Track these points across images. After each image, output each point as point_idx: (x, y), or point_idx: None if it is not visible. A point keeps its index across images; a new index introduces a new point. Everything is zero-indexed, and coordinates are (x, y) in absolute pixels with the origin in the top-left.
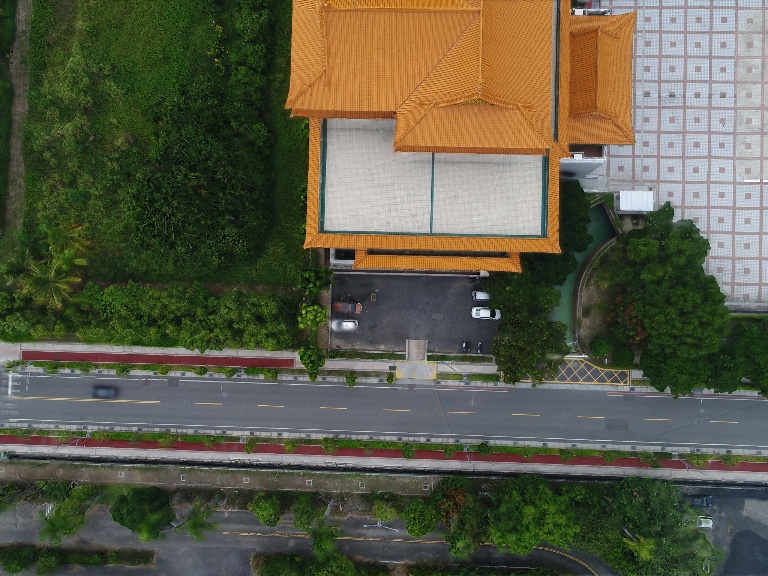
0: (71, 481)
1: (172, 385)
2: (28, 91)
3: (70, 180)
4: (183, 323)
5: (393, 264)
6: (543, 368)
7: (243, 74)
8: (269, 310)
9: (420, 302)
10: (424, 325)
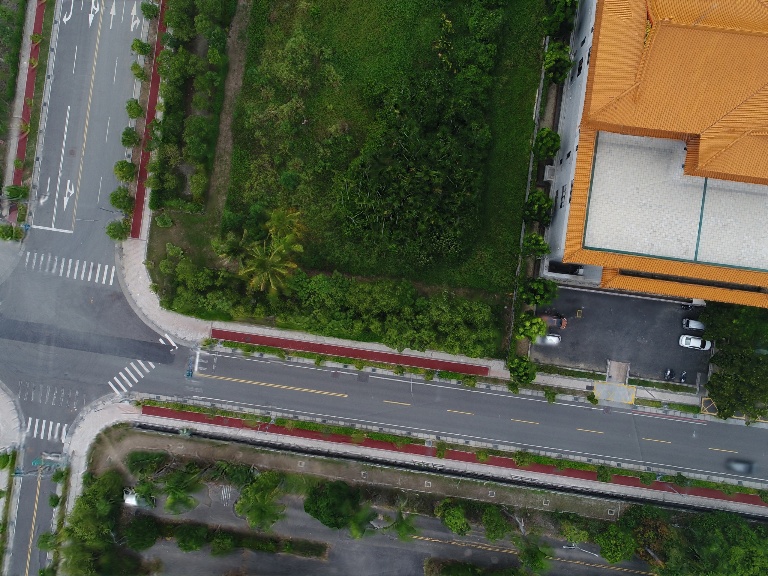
0: (251, 465)
1: (361, 380)
2: (243, 67)
3: (280, 162)
4: (388, 320)
5: (641, 287)
6: (765, 407)
7: (473, 73)
8: (482, 317)
9: (626, 324)
10: (628, 348)
